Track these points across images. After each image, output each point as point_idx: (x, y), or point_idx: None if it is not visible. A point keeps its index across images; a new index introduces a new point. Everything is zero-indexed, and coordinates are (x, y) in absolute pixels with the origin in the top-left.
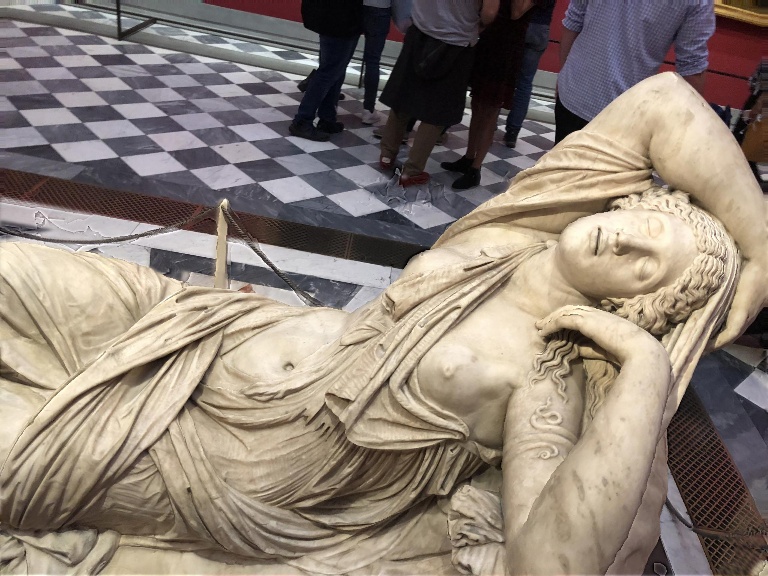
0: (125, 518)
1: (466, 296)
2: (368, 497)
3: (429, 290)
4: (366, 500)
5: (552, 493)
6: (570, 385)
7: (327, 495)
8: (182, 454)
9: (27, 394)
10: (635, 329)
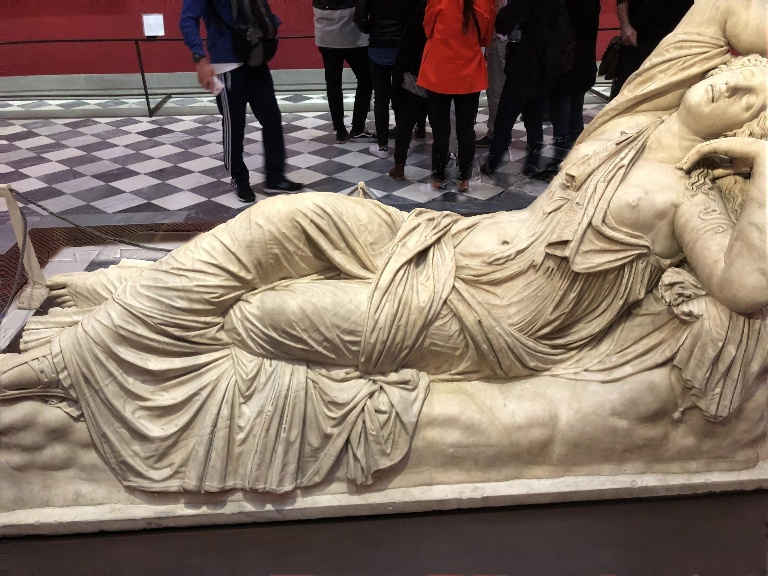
0: (435, 356)
1: (625, 158)
2: (583, 321)
3: (597, 162)
4: (582, 324)
5: (738, 239)
6: (715, 194)
7: (559, 320)
8: (469, 298)
9: (354, 283)
10: (754, 139)
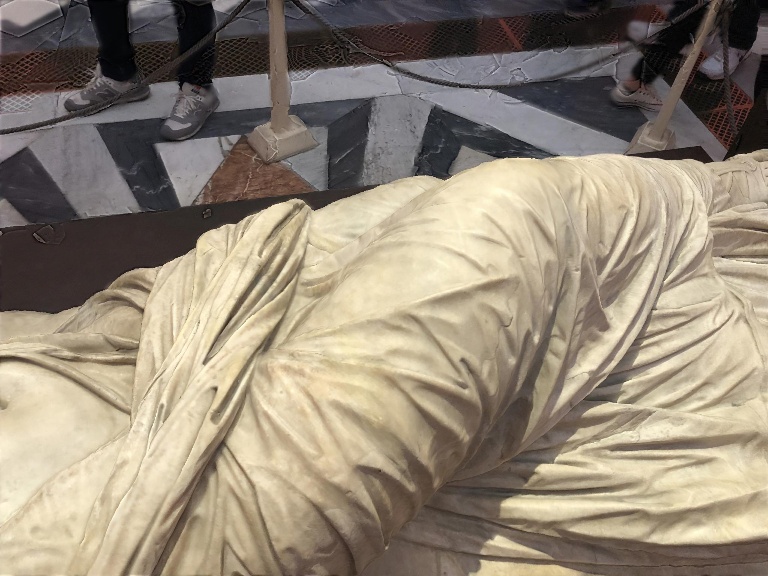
0: None
1: None
2: None
3: None
4: None
5: None
6: None
7: None
8: None
9: None
10: None
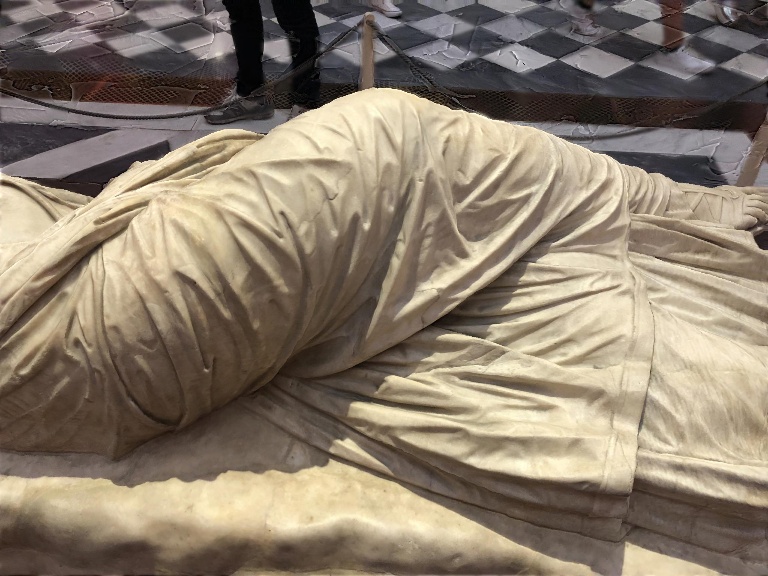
0: None
1: None
2: None
3: None
4: None
5: None
6: None
7: None
8: None
9: None
10: None
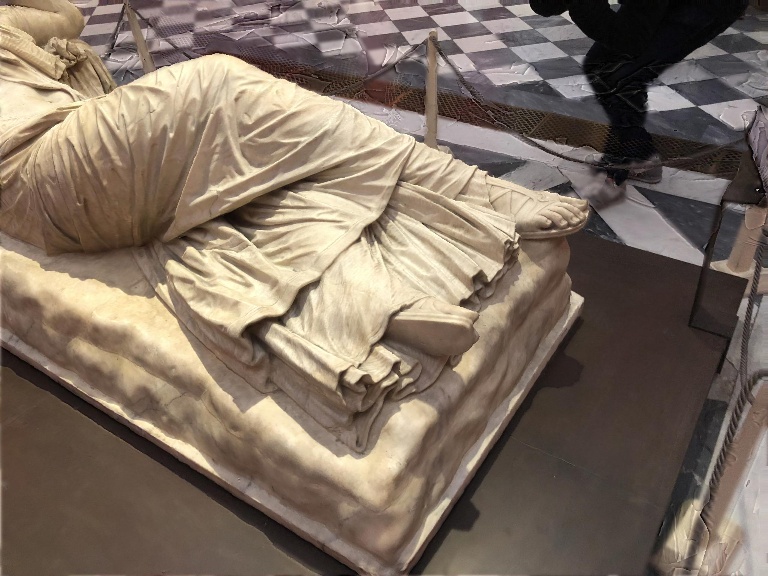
0: None
1: None
2: None
3: None
4: None
5: None
6: None
7: None
8: None
9: None
10: None
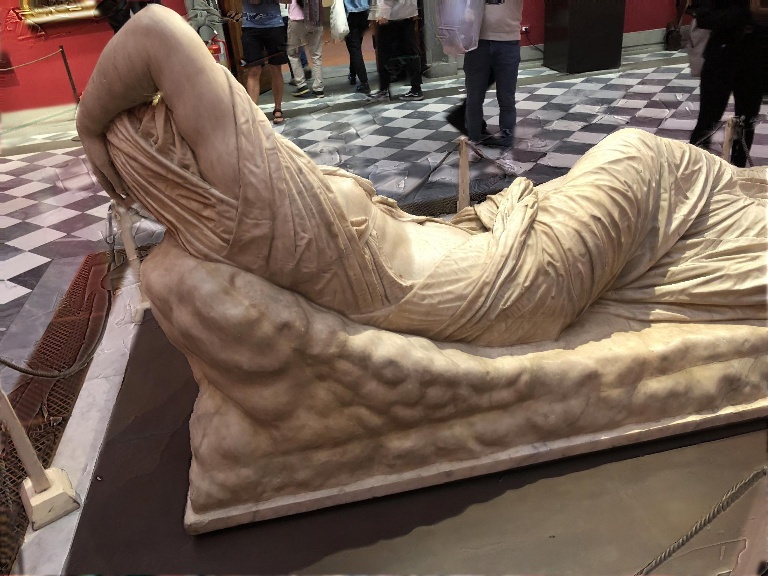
0: None
1: None
2: None
3: None
4: None
5: None
6: None
7: None
8: None
9: None
10: None
